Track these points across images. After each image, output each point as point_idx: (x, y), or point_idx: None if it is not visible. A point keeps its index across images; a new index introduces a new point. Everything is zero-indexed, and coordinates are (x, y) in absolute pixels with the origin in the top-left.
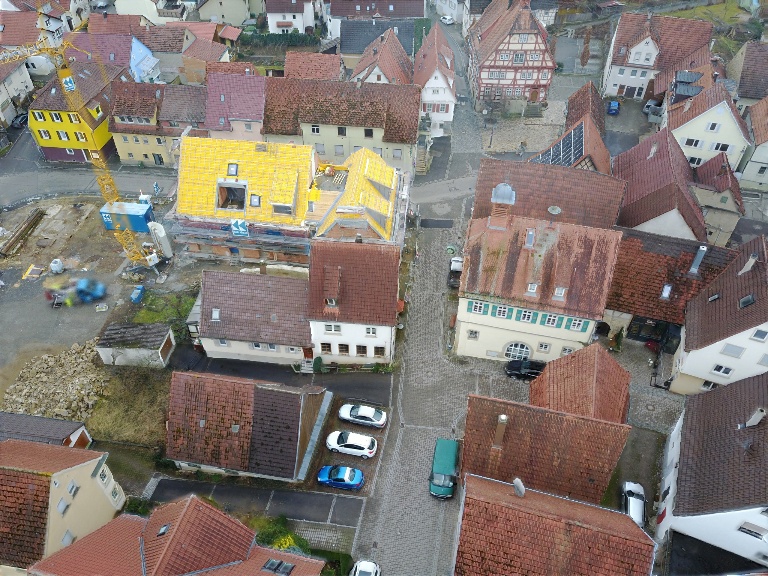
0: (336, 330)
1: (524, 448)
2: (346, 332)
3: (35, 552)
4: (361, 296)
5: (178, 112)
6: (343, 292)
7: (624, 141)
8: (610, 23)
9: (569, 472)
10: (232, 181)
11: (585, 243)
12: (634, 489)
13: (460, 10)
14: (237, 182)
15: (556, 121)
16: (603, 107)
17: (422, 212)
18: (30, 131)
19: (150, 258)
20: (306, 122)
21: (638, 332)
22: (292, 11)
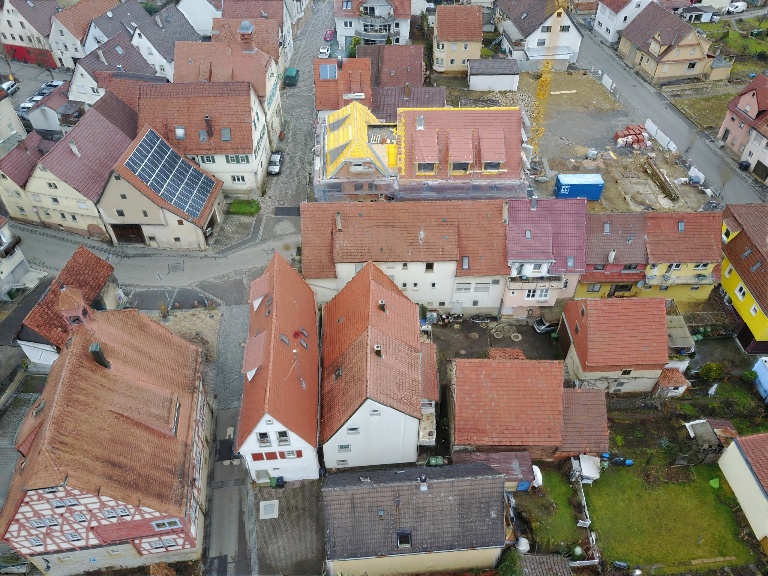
0: None
1: None
2: None
3: None
4: None
5: None
6: None
7: (16, 328)
8: None
9: None
10: None
11: None
12: None
13: None
14: None
15: None
16: None
17: None
18: None
19: None
20: None
21: None
22: None
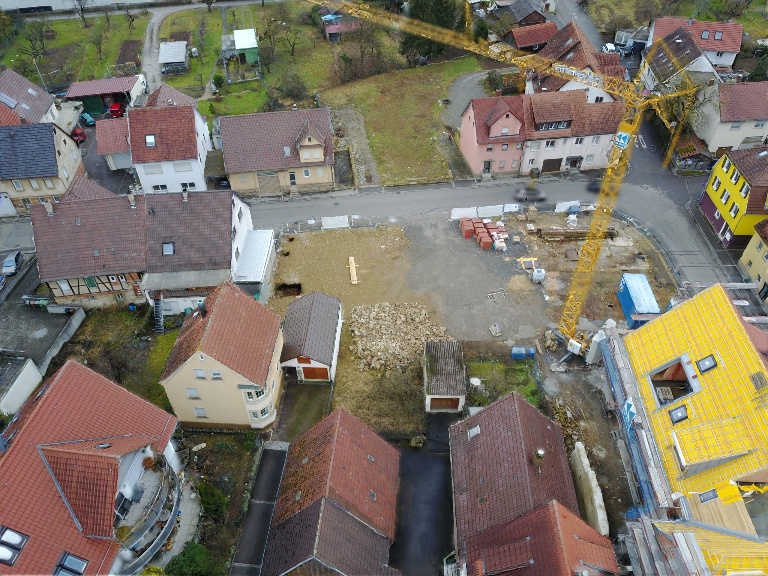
0: None
1: None
2: None
3: (168, 372)
4: None
5: None
6: None
7: None
8: None
9: None
10: (691, 372)
11: None
12: None
13: None
14: (693, 378)
15: None
16: None
17: None
18: (711, 172)
19: (572, 343)
20: None
21: None
22: None
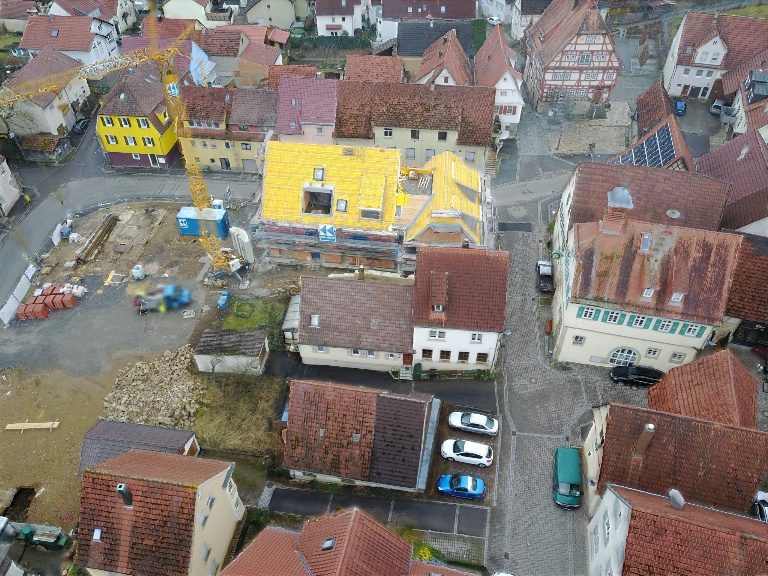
0: (440, 336)
1: (667, 458)
2: (451, 338)
3: (180, 565)
4: (468, 302)
5: (248, 116)
6: (450, 298)
7: (694, 142)
8: (662, 22)
9: (715, 482)
10: (318, 186)
11: (703, 247)
12: (767, 498)
13: (508, 11)
14: (323, 187)
15: (621, 122)
16: (673, 108)
17: (498, 215)
18: (97, 136)
19: (233, 264)
20: (379, 125)
21: (744, 337)
22: (342, 13)
